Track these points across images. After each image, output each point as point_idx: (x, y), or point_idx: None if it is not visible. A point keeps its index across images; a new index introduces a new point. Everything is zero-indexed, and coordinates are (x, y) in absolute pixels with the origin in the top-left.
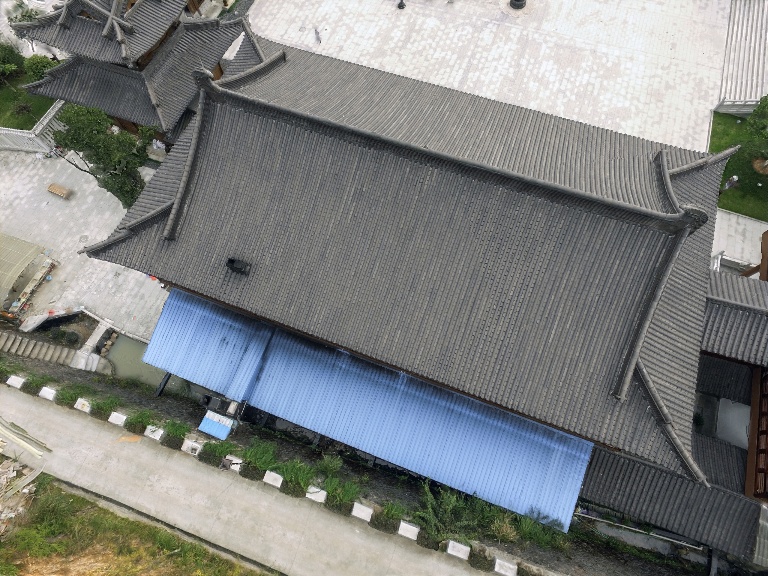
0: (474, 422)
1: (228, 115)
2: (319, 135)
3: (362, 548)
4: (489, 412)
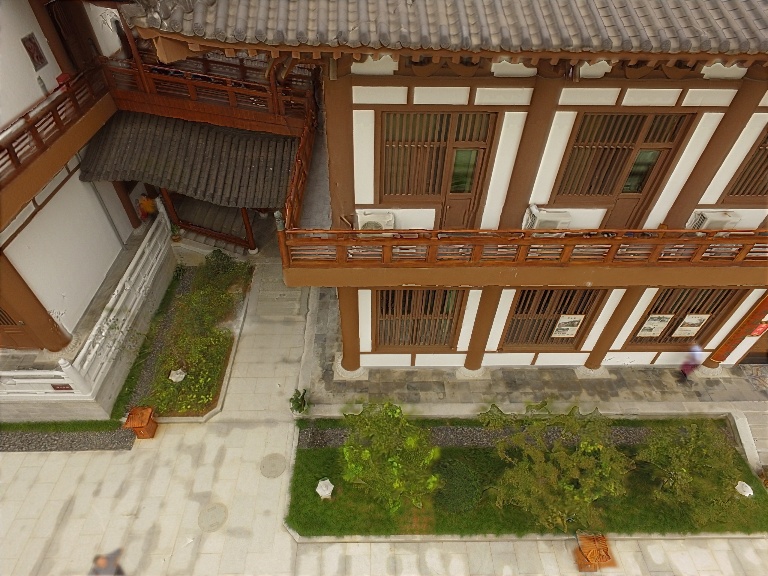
0: None
1: None
2: None
3: None
4: None
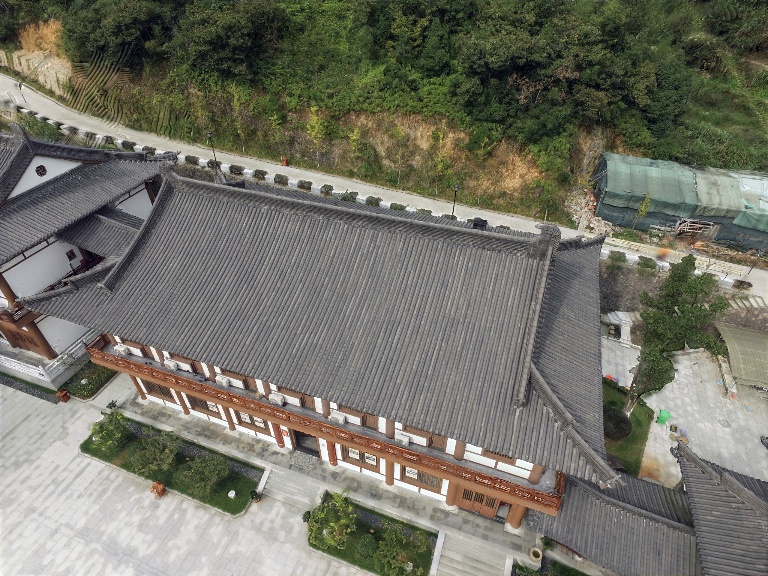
0: None
1: None
2: None
3: (385, 200)
4: None
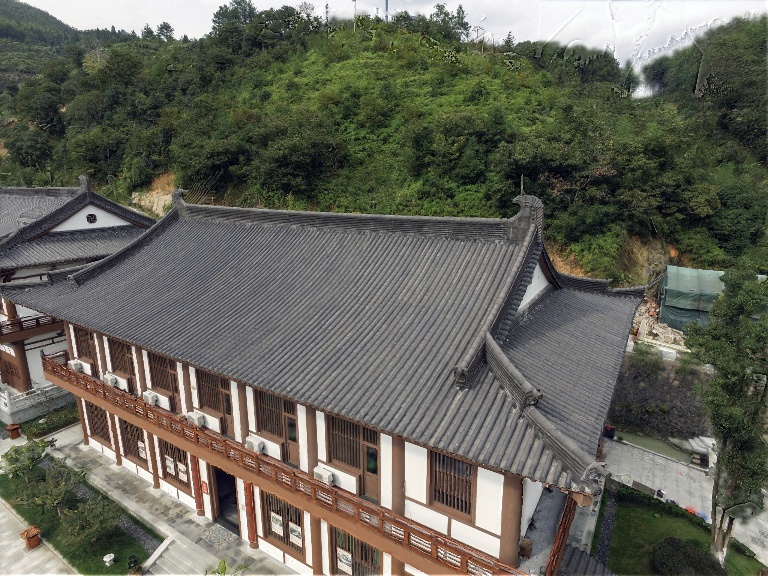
0: None
1: None
2: None
3: None
4: None
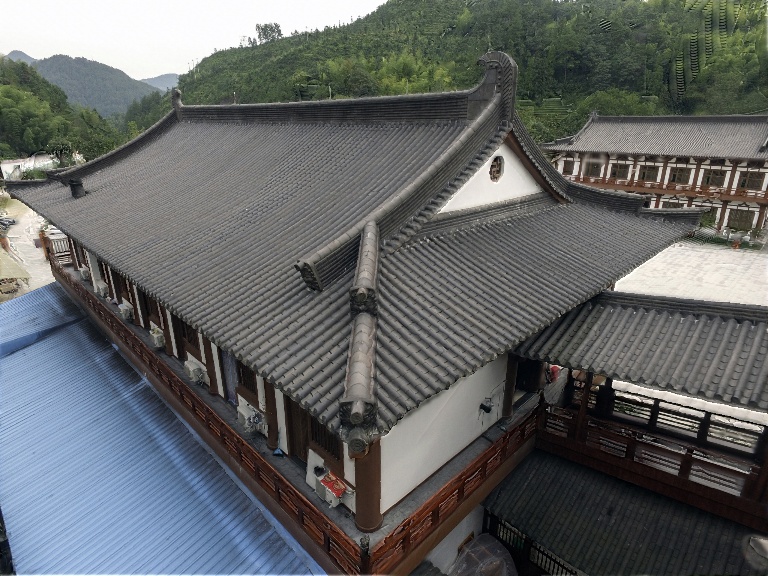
0: (162, 465)
1: (180, 127)
2: (222, 125)
3: None
4: (197, 457)
